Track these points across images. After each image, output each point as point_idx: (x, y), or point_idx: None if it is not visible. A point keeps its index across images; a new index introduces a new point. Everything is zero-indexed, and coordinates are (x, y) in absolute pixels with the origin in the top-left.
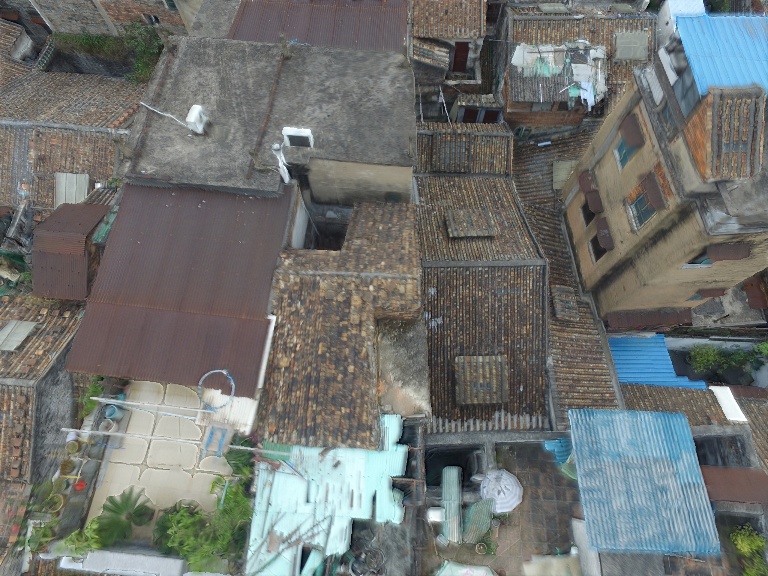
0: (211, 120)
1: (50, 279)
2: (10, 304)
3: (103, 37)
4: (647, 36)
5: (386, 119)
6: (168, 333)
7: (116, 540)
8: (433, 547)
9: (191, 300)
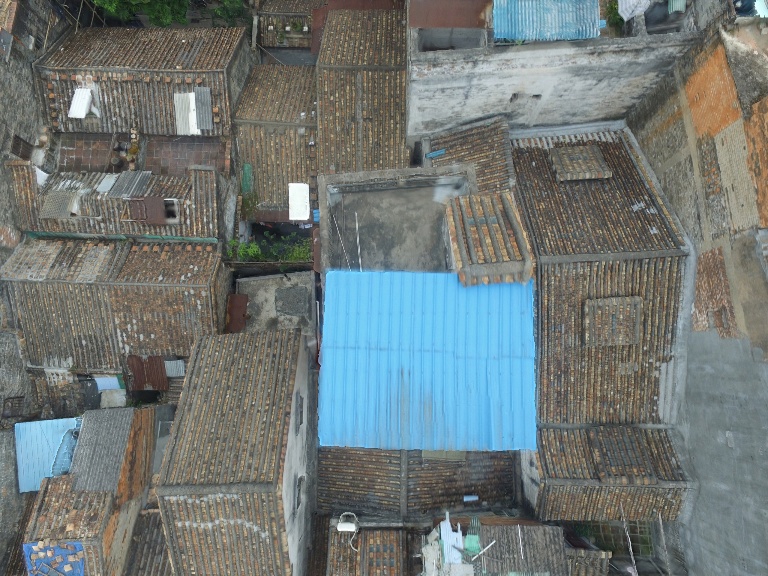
0: None
1: None
2: None
3: None
4: None
5: None
6: None
7: None
8: None
9: None
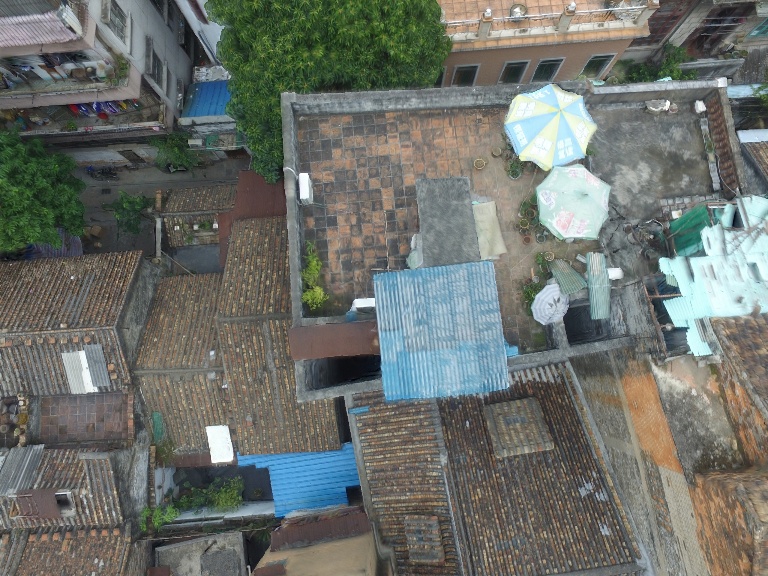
0: None
1: None
2: None
3: None
4: None
5: None
6: None
7: None
8: None
9: None
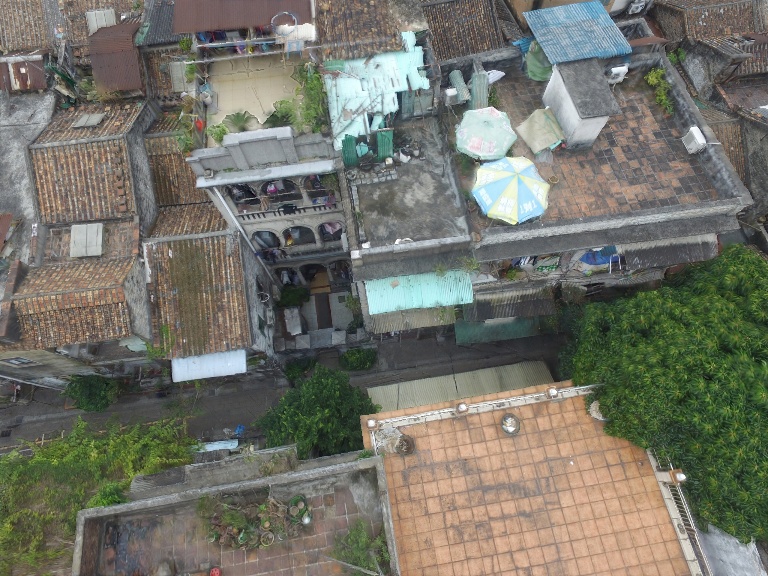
0: None
1: (109, 76)
2: (77, 111)
3: None
4: None
5: None
6: (239, 1)
7: (239, 131)
8: (453, 133)
9: None
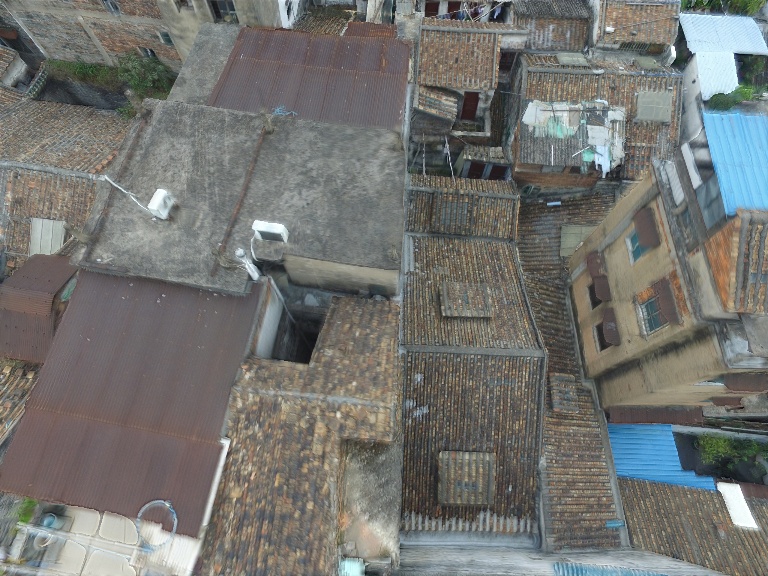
0: (179, 202)
1: (14, 338)
2: None
3: (98, 66)
4: (671, 96)
5: (371, 212)
6: (110, 451)
7: None
8: None
9: (139, 413)
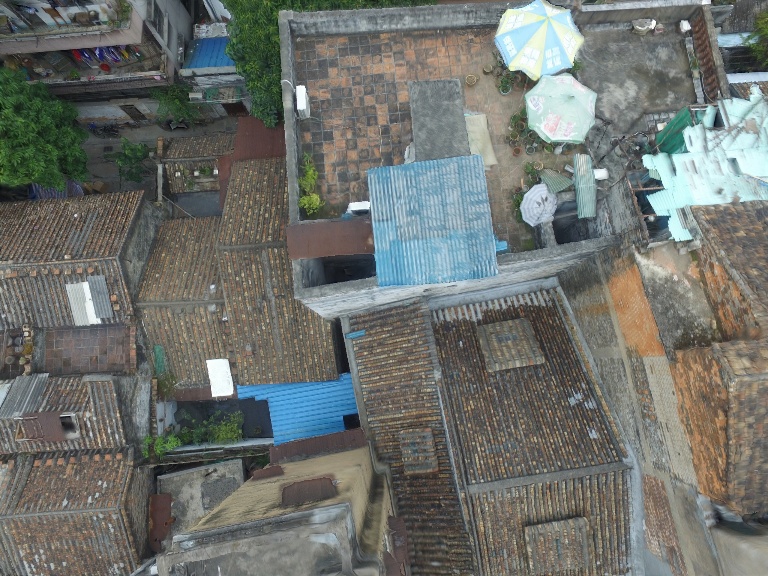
0: None
1: None
2: None
3: None
4: None
5: None
6: None
7: None
8: None
9: None
